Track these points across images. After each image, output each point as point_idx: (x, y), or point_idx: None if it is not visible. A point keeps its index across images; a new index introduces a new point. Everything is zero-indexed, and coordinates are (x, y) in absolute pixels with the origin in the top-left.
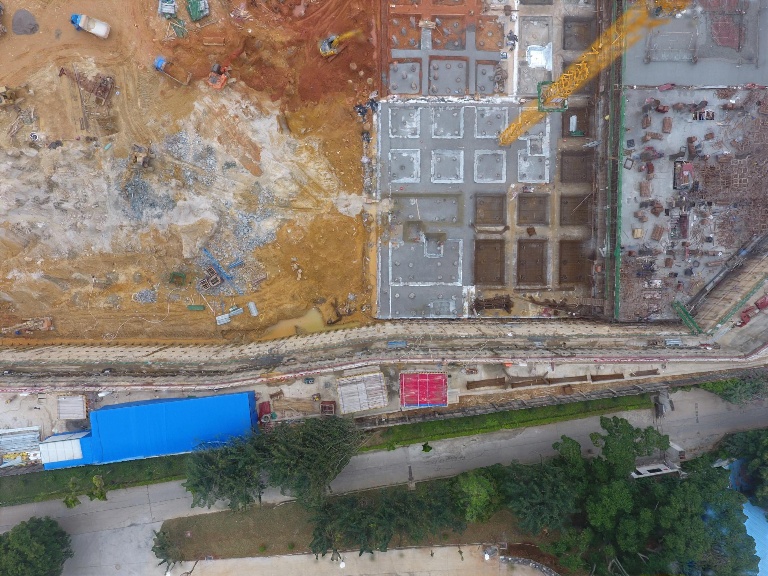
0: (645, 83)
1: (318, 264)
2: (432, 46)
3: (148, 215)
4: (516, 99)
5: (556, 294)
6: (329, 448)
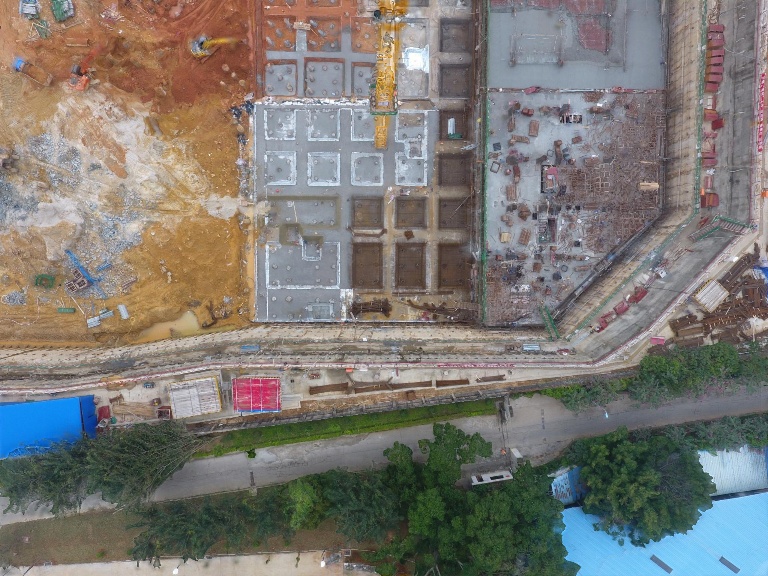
0: (511, 86)
1: (187, 267)
2: (307, 48)
3: (12, 217)
4: None
5: (435, 298)
6: (153, 454)
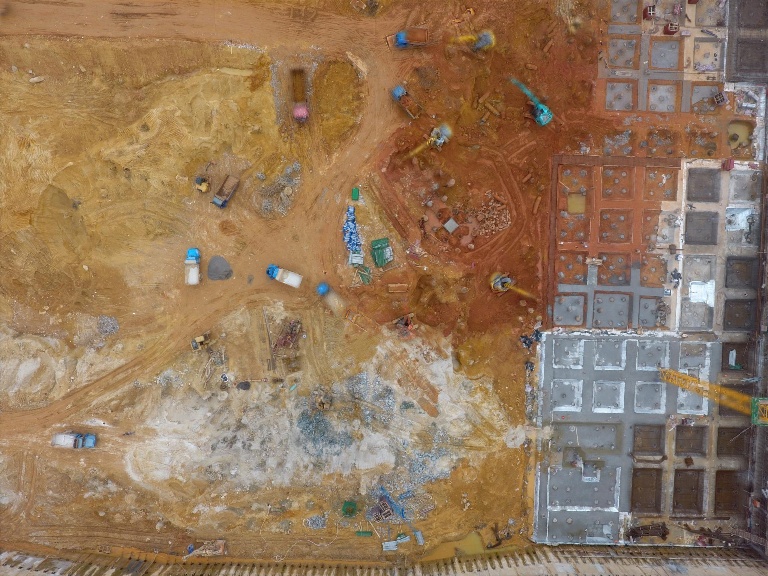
0: None
1: (487, 499)
2: (597, 281)
3: (328, 453)
4: (678, 333)
5: (711, 523)
6: None
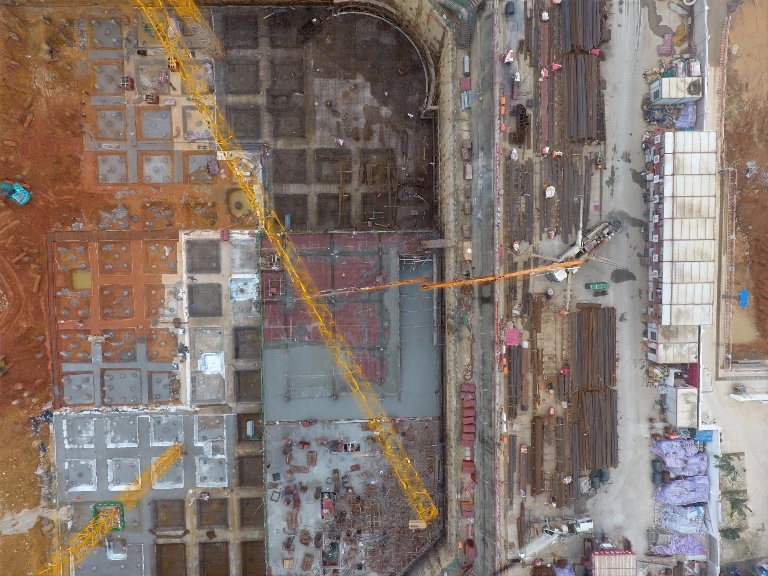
0: (288, 418)
1: None
2: (103, 358)
3: None
4: (191, 407)
5: None
6: None
